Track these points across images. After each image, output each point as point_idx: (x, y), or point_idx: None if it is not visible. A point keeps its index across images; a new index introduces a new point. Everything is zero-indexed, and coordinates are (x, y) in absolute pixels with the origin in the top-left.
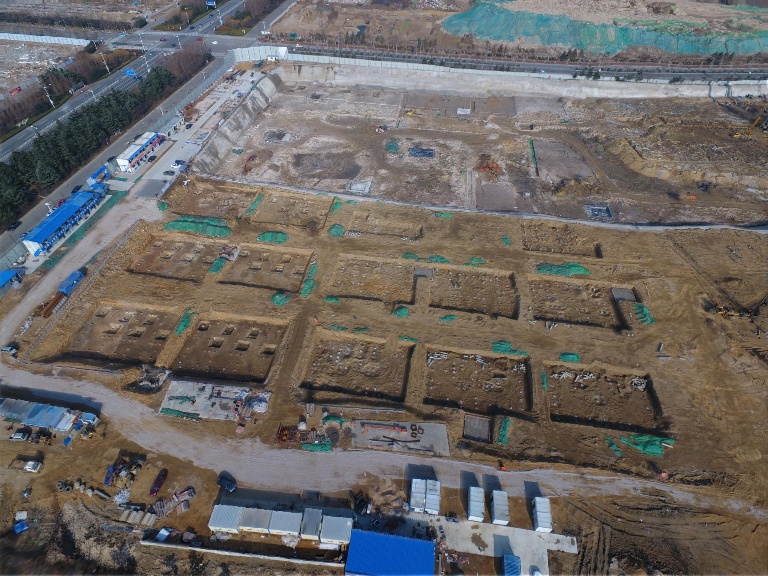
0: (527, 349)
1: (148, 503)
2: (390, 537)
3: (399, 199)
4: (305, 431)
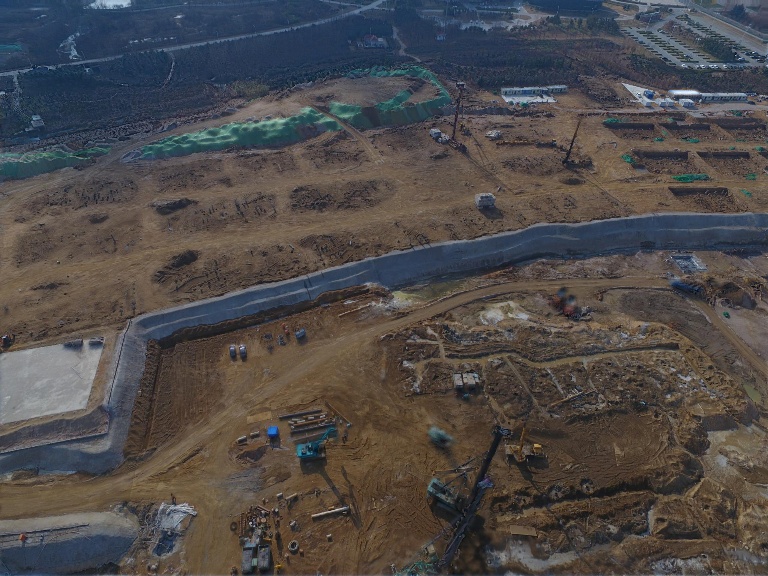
0: (681, 141)
1: (767, 99)
2: (689, 94)
3: None
4: (744, 113)
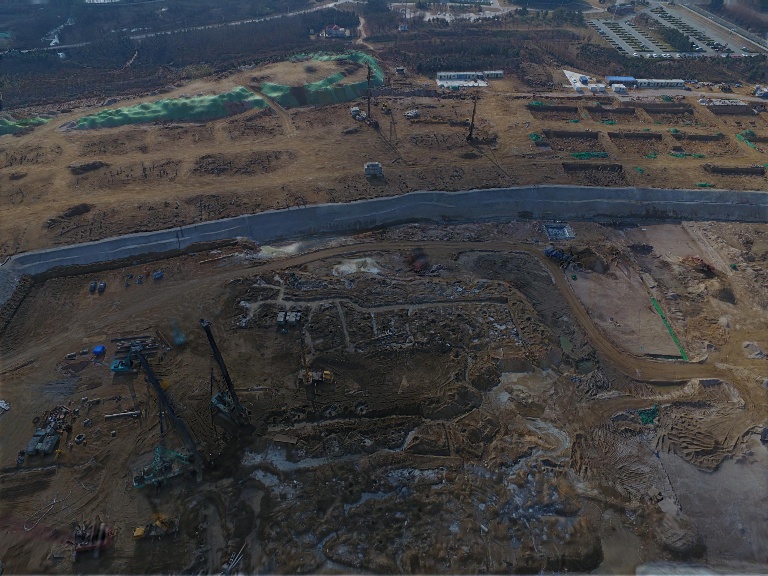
0: (597, 123)
1: None
2: (624, 80)
3: (764, 224)
4: (675, 98)
